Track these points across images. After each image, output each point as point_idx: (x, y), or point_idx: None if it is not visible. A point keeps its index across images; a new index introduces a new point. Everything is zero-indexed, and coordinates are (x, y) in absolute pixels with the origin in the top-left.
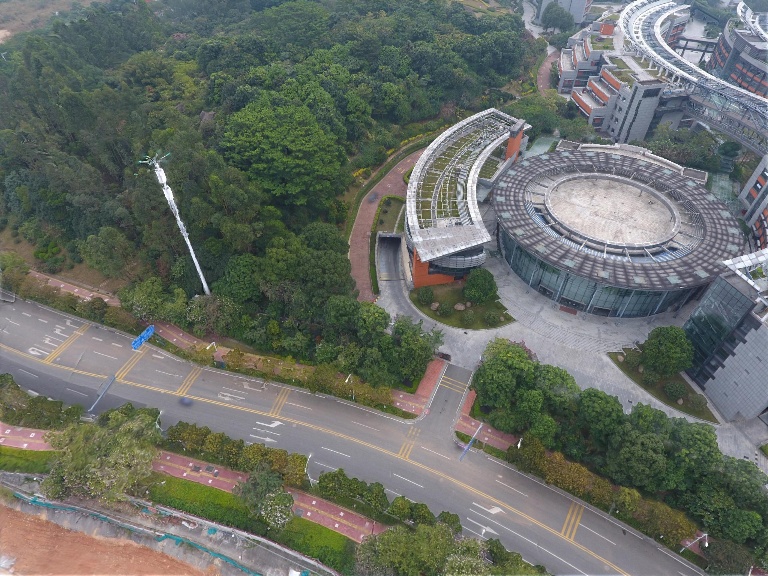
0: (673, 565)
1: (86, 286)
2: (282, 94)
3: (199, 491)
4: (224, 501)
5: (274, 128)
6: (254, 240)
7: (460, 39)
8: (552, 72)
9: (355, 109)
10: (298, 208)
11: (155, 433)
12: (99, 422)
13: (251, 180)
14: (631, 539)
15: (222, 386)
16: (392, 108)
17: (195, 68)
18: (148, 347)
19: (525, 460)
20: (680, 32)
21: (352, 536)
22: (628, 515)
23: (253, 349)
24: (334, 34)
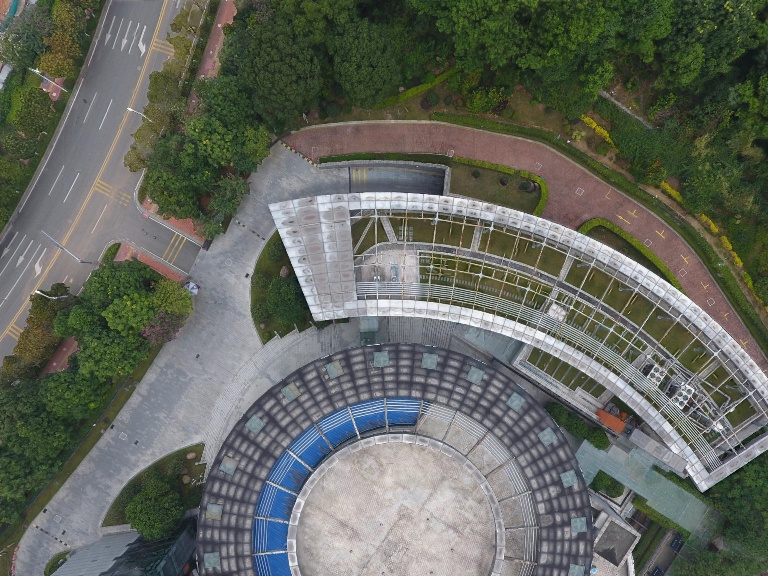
0: None
1: None
2: None
3: None
4: None
5: None
6: None
7: None
8: None
9: (766, 94)
10: None
11: None
12: None
13: None
14: None
15: None
16: None
17: None
18: None
19: None
20: None
21: None
22: None
23: None
24: None
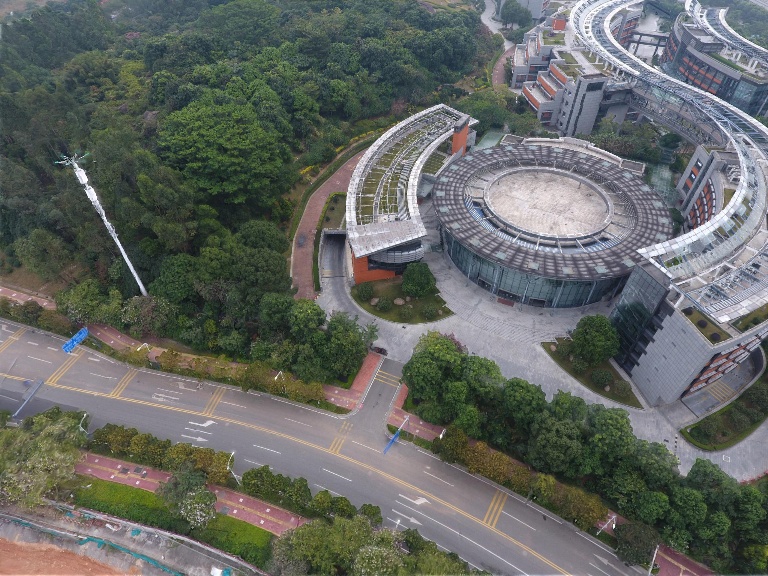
0: (589, 548)
1: (25, 290)
2: (227, 92)
3: (125, 493)
4: (150, 502)
5: (211, 126)
6: (189, 239)
7: (413, 35)
8: (505, 67)
9: (302, 106)
10: (240, 207)
11: (79, 436)
12: (24, 427)
13: (186, 179)
14: (551, 524)
15: (157, 387)
16: (341, 105)
17: (142, 67)
18: (84, 350)
19: (447, 450)
20: (633, 27)
21: (277, 532)
22: (544, 501)
23: (191, 349)
24: (284, 31)
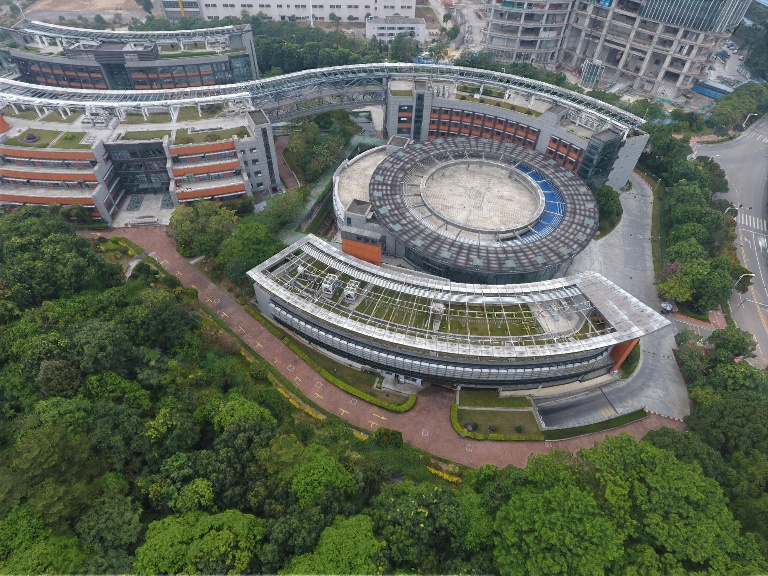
0: None
1: None
2: None
3: None
4: None
5: None
6: None
7: None
8: (72, 211)
9: None
10: None
11: None
12: None
13: None
14: None
15: None
16: None
17: None
18: None
19: None
20: None
21: None
22: None
23: None
24: None
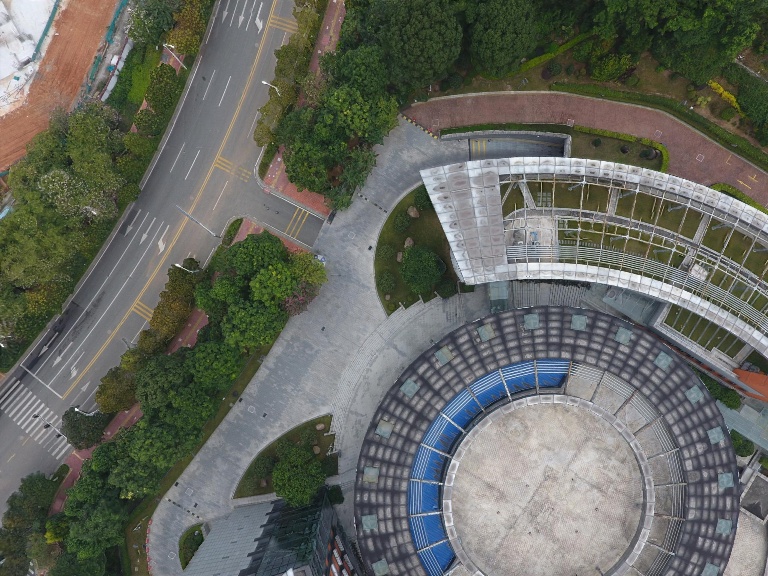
0: None
1: None
2: None
3: None
4: None
5: None
6: None
7: None
8: None
9: None
10: None
11: None
12: None
13: None
14: None
15: None
16: None
17: None
18: None
19: None
20: None
21: None
22: None
23: None
24: None
